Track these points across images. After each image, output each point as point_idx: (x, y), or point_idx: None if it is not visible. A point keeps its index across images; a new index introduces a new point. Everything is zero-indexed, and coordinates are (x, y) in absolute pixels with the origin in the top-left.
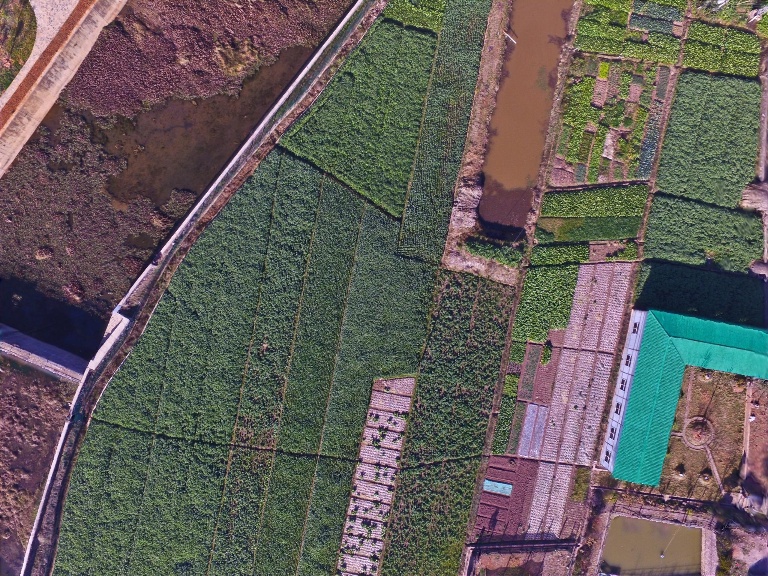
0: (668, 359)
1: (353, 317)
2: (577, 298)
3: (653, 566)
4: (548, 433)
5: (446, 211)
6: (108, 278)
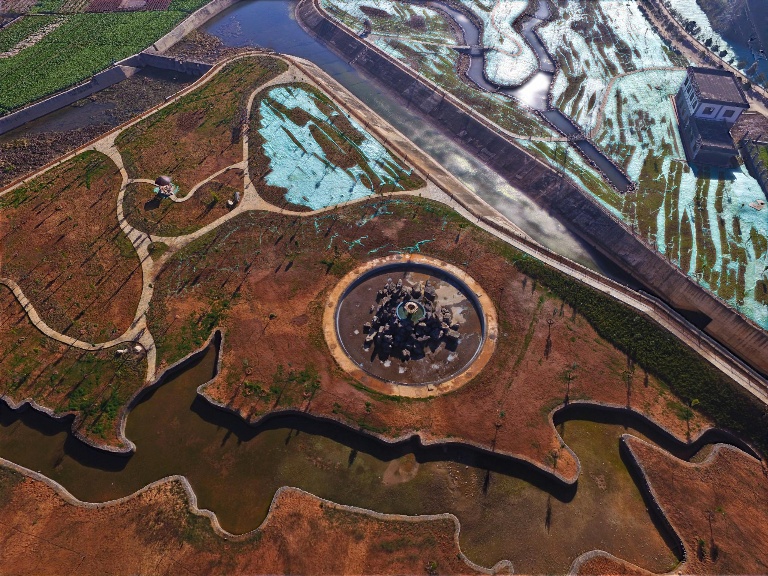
0: None
1: (8, 68)
2: None
3: None
4: None
5: None
6: None
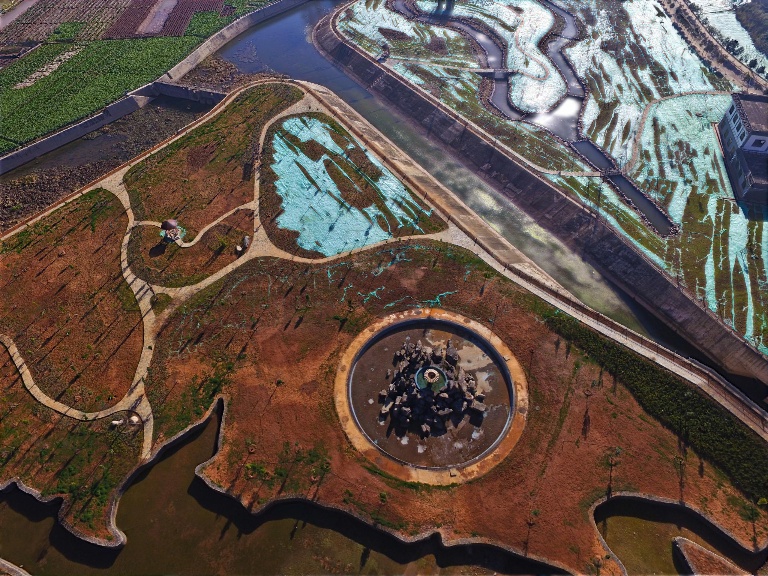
0: None
1: None
2: None
3: None
4: None
5: None
6: None
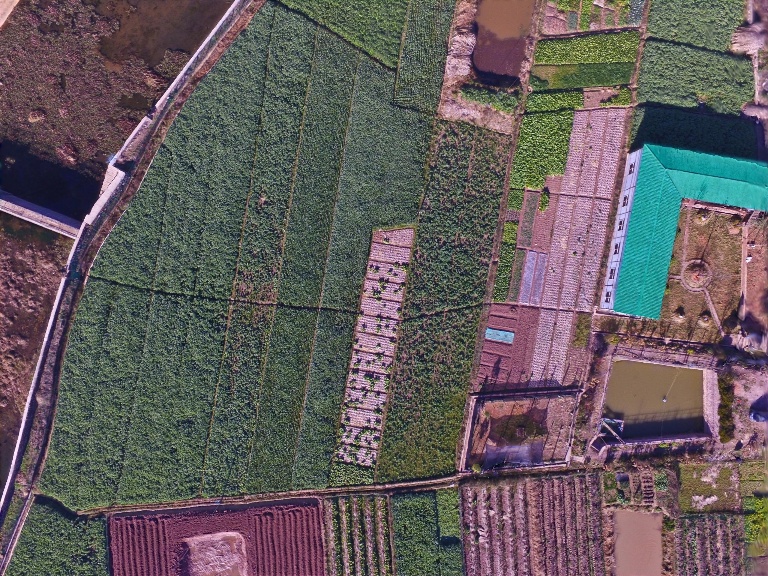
0: (665, 192)
1: (351, 167)
2: (573, 145)
3: (656, 411)
4: (548, 280)
5: (441, 60)
6: (102, 139)
